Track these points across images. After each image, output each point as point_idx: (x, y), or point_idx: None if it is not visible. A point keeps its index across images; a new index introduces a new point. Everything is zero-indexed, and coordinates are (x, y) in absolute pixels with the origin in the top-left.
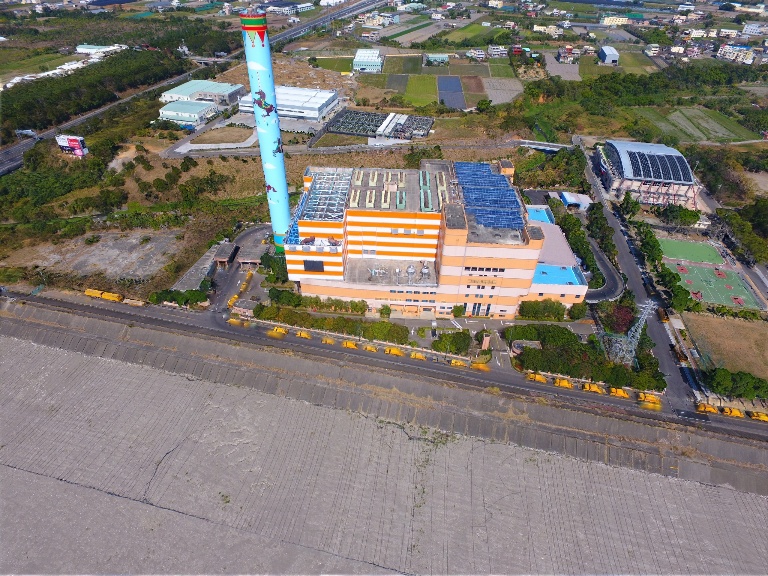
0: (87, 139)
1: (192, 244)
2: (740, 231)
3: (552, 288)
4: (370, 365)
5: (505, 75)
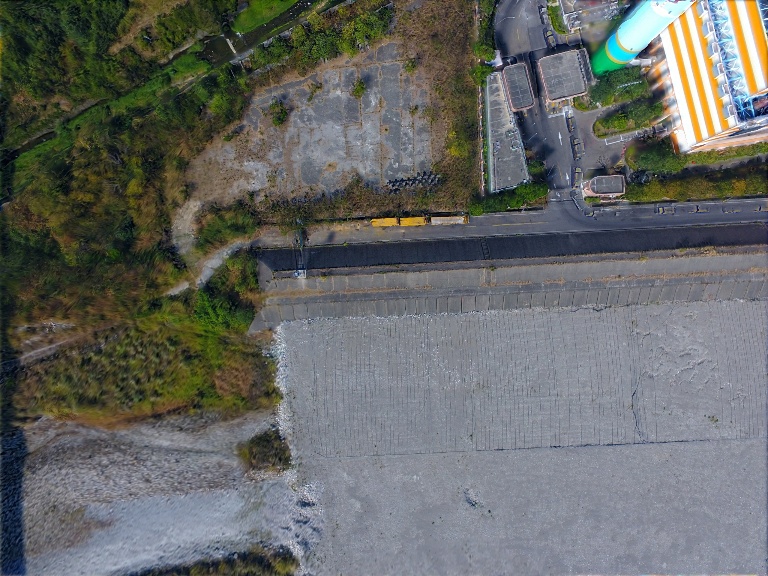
0: None
1: (438, 74)
2: None
3: None
4: None
5: None
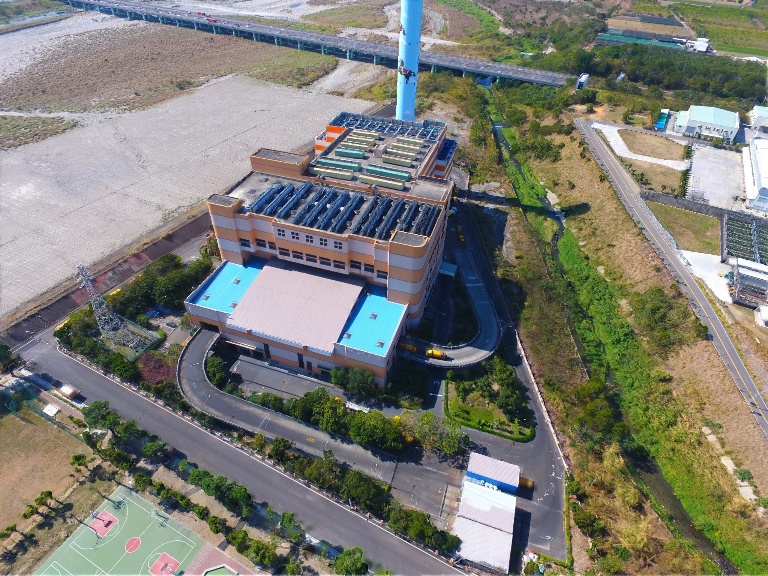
0: (611, 93)
1: None
2: None
3: None
4: None
5: None
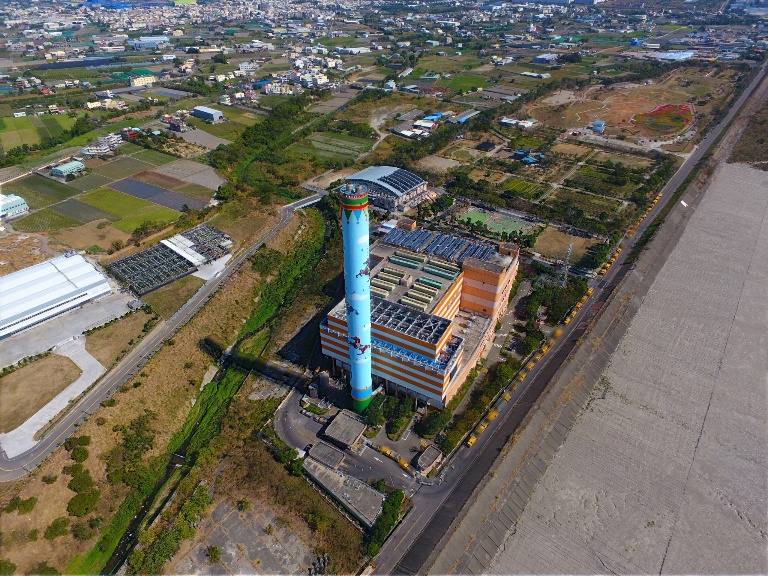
0: None
1: (268, 493)
2: (476, 196)
3: None
4: (542, 391)
5: (166, 160)
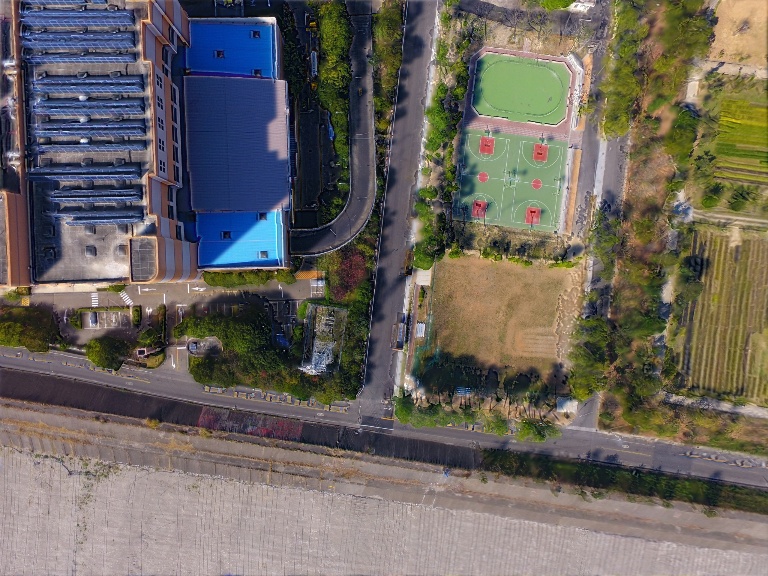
0: None
1: None
2: (620, 48)
3: None
4: (4, 397)
5: None
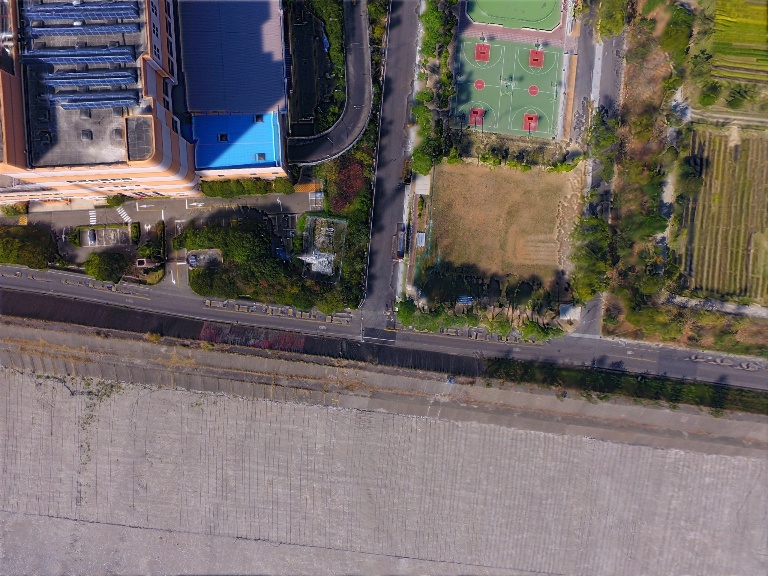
0: None
1: None
2: None
3: (231, 172)
4: (4, 314)
5: None
